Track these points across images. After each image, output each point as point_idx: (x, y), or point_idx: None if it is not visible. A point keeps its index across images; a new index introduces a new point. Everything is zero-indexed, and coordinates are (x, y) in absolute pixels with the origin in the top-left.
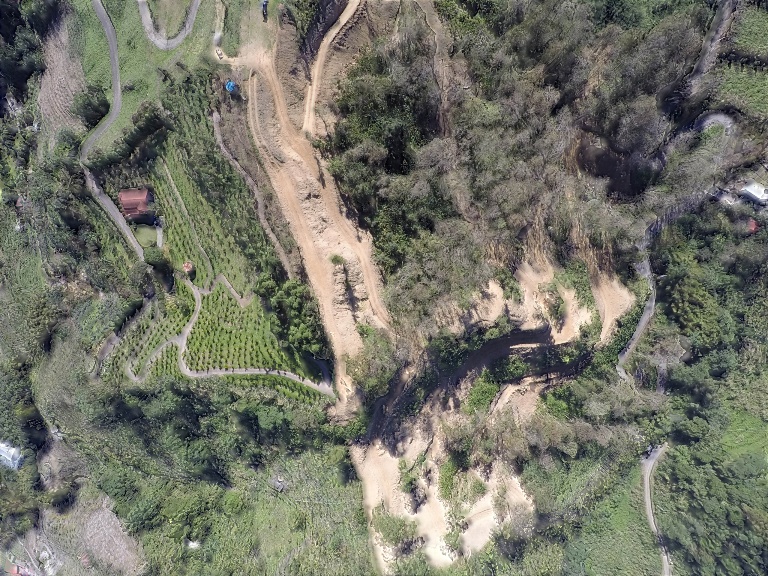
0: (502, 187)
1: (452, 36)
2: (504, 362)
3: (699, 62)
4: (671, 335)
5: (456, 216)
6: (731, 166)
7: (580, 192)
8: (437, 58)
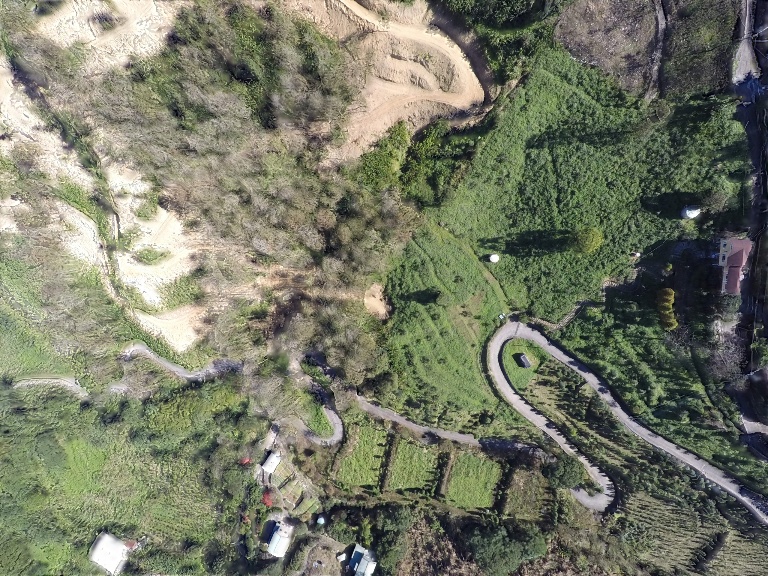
0: (190, 162)
1: (374, 143)
2: (107, 212)
3: (377, 410)
4: (146, 380)
5: (184, 132)
6: (295, 446)
7: (263, 294)
8: (349, 125)
